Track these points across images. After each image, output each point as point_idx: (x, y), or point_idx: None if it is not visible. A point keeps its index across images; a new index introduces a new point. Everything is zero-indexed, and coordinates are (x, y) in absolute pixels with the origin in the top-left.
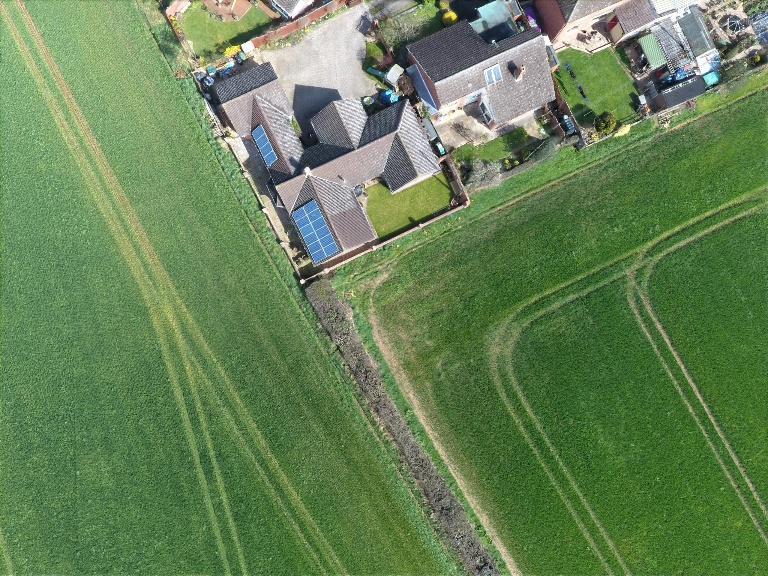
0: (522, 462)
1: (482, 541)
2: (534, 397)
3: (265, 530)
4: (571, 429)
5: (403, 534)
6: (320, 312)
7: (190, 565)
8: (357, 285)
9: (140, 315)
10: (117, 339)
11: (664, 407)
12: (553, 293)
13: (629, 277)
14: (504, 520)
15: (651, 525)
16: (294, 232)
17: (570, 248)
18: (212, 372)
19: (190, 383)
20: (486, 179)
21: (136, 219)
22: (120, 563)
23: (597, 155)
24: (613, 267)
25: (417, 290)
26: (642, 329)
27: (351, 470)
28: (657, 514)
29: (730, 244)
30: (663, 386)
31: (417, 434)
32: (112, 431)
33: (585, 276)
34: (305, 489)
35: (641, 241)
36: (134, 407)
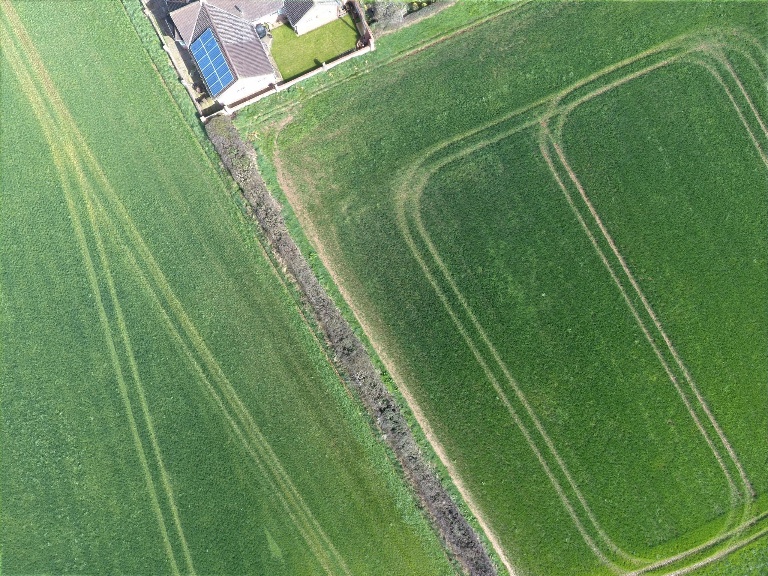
0: (429, 309)
1: (387, 387)
2: (442, 243)
3: (166, 369)
4: (480, 276)
5: (307, 378)
6: (220, 148)
7: (91, 402)
8: (261, 127)
9: (41, 151)
10: (18, 175)
11: (577, 257)
12: (462, 139)
13: (542, 125)
14: (410, 367)
15: (562, 376)
16: (198, 73)
17: (480, 94)
18: (113, 210)
19: (91, 221)
20: (388, 14)
21: (38, 57)
22: (21, 397)
23: (509, 0)
24: (525, 114)
25: (322, 133)
26: (555, 178)
27: (254, 312)
28: (569, 365)
29: (648, 93)
30: (576, 236)
31: (321, 277)
32: (12, 266)
33: (496, 123)
34: (207, 329)
35: (554, 88)
36: (35, 243)
